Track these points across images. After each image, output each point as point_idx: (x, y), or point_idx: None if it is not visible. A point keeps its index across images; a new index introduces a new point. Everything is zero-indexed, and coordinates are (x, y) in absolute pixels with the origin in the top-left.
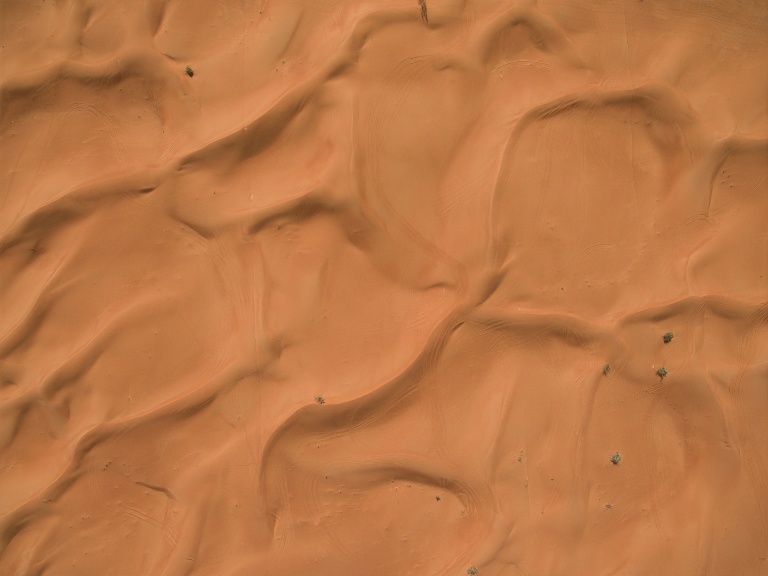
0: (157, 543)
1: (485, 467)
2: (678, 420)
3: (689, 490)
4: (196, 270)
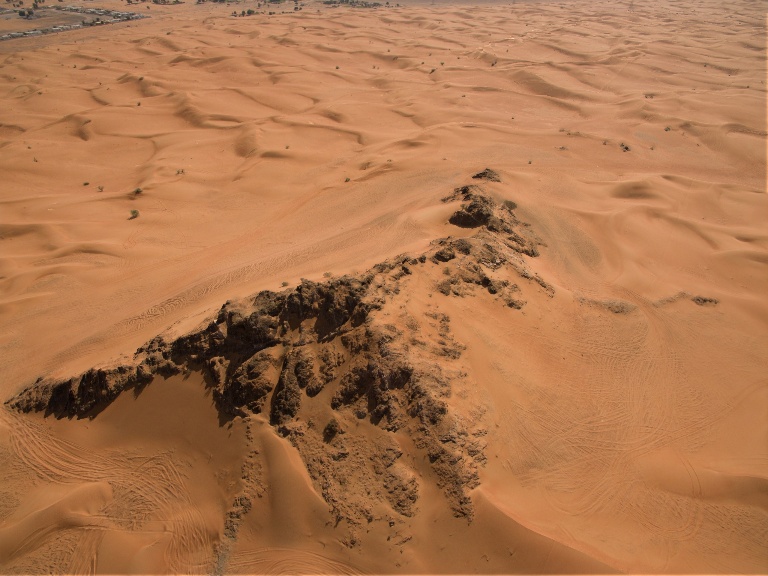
0: None
1: None
2: None
3: None
4: None
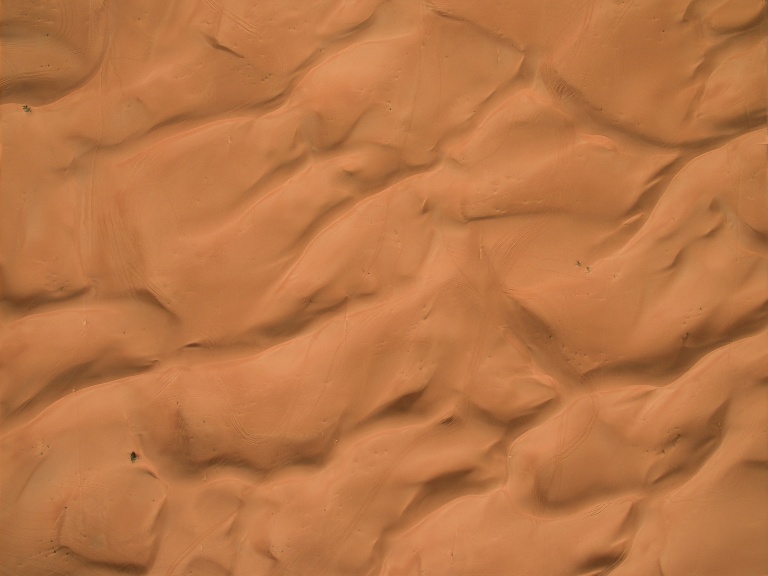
0: None
1: None
2: None
3: None
4: (161, 260)
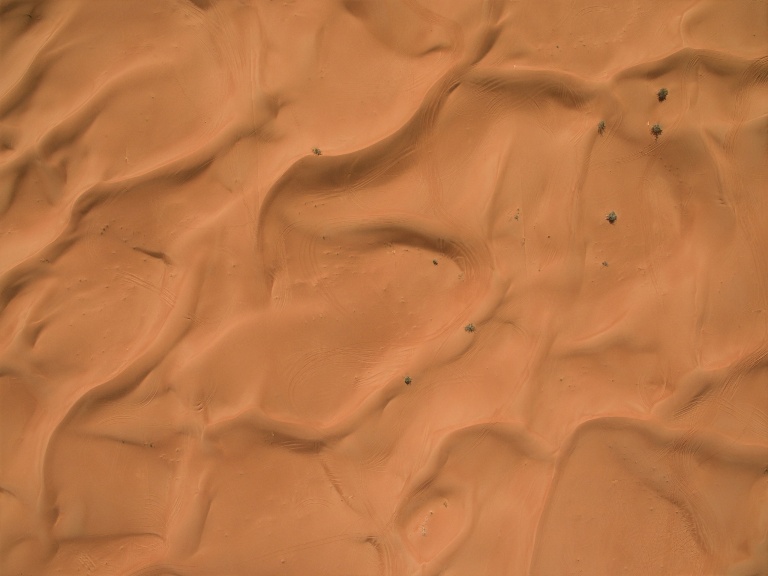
0: (155, 306)
1: (482, 224)
2: (673, 182)
3: (685, 249)
4: (193, 40)
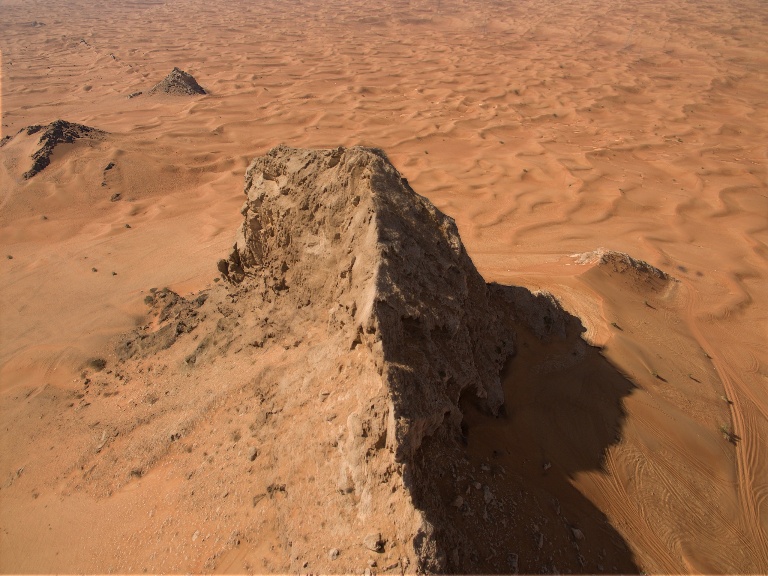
0: None
1: None
2: None
3: None
4: None
